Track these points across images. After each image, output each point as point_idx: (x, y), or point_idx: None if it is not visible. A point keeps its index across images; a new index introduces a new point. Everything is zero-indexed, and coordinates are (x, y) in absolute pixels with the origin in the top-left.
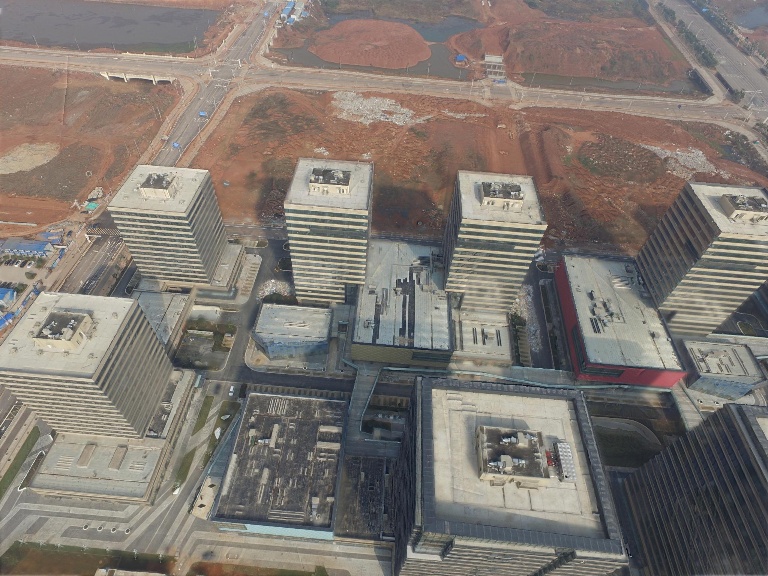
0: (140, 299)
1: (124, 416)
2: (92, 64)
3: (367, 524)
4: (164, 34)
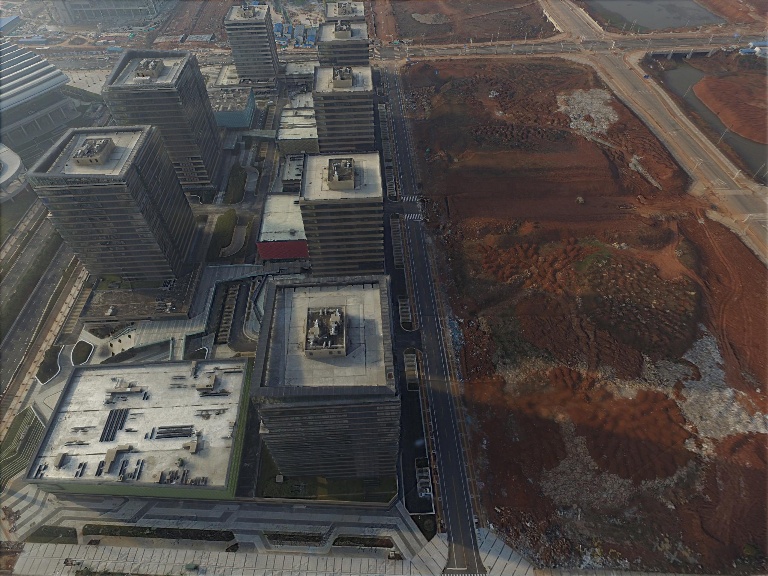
0: None
1: (233, 55)
2: (553, 5)
3: None
4: (644, 16)
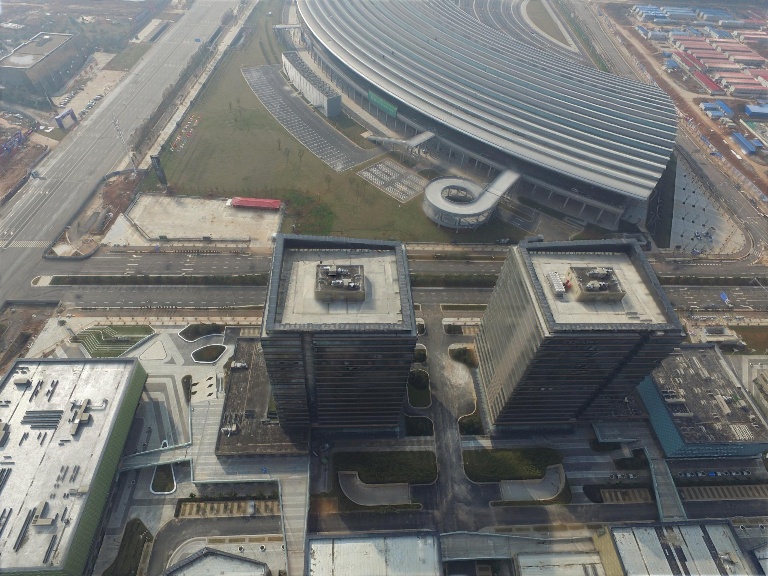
0: None
1: None
2: None
3: None
4: None
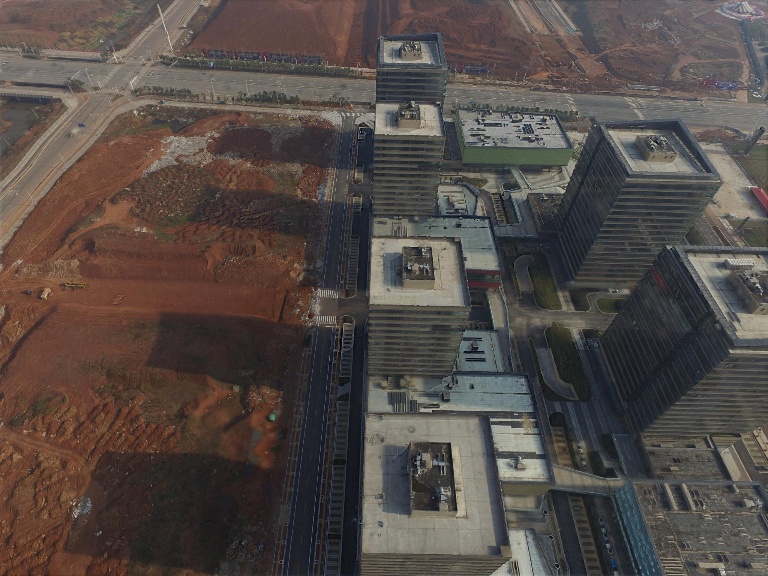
0: None
1: None
2: None
3: (709, 463)
4: None
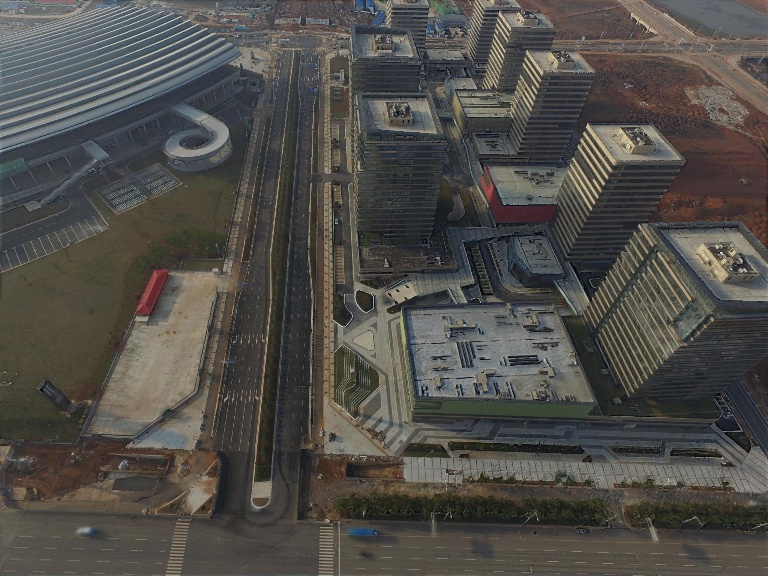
0: (455, 51)
1: None
2: None
3: None
4: (720, 24)
